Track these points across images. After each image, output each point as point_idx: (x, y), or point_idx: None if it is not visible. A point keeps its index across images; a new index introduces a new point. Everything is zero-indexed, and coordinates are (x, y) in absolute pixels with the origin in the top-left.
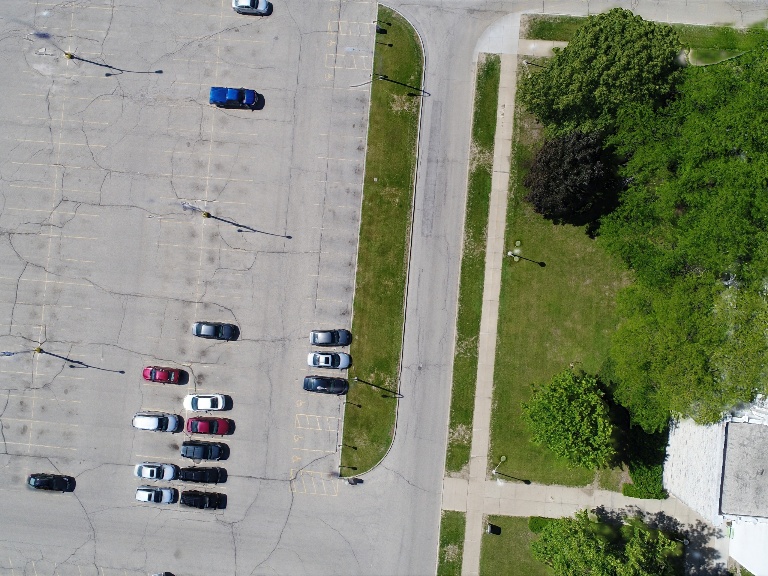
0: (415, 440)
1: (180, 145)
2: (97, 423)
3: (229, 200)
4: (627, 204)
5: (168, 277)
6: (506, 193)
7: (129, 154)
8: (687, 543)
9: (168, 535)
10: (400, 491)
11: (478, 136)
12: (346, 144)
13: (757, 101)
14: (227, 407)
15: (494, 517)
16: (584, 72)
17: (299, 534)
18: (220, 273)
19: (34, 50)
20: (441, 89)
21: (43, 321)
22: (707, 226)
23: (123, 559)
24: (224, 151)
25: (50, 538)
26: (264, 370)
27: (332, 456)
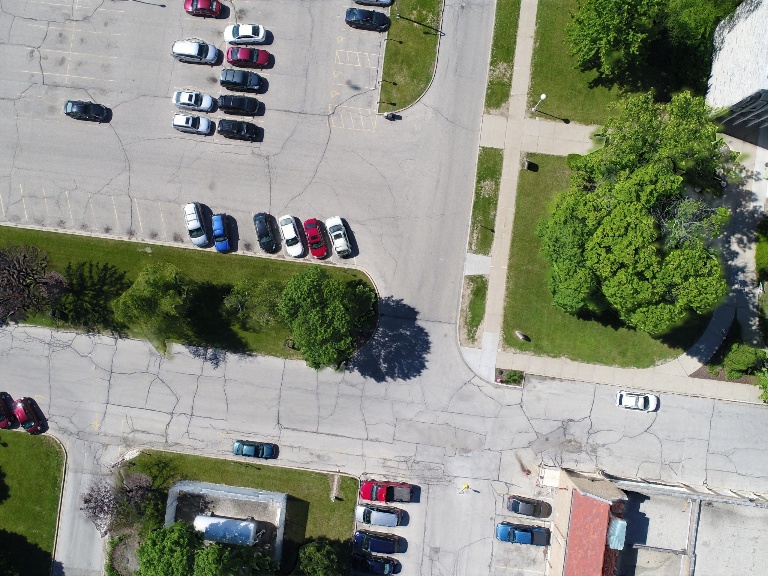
0: (455, 78)
1: None
2: (136, 56)
3: None
4: None
5: None
6: None
7: None
8: (725, 185)
9: (203, 167)
10: (438, 128)
11: None
12: None
13: None
14: (267, 41)
15: (532, 155)
16: None
17: (335, 168)
18: None
19: None
20: None
21: None
22: None
23: (157, 190)
24: None
25: (85, 168)
26: (306, 6)
27: (371, 92)
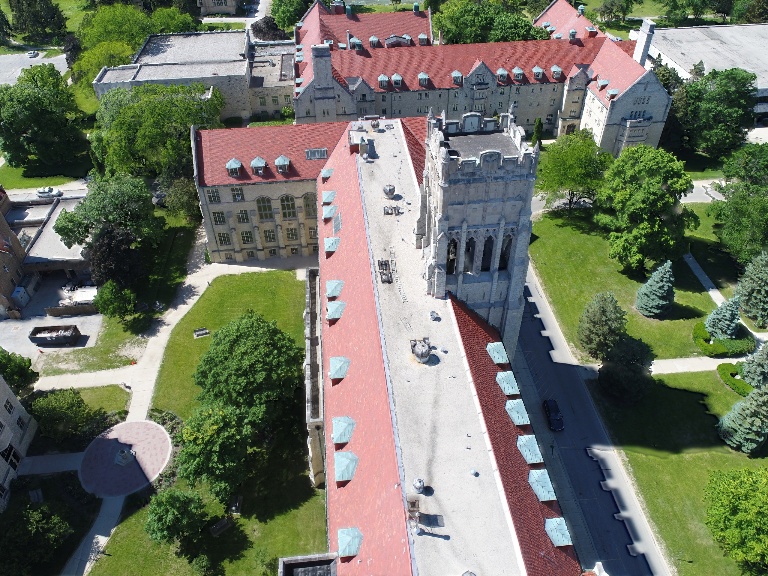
0: None
1: None
2: None
3: None
4: (84, 45)
5: None
6: None
7: None
8: None
9: None
10: None
11: None
12: None
13: None
14: None
15: None
16: None
17: None
18: None
19: None
20: None
21: None
22: None
23: None
24: None
25: None
26: None
27: None
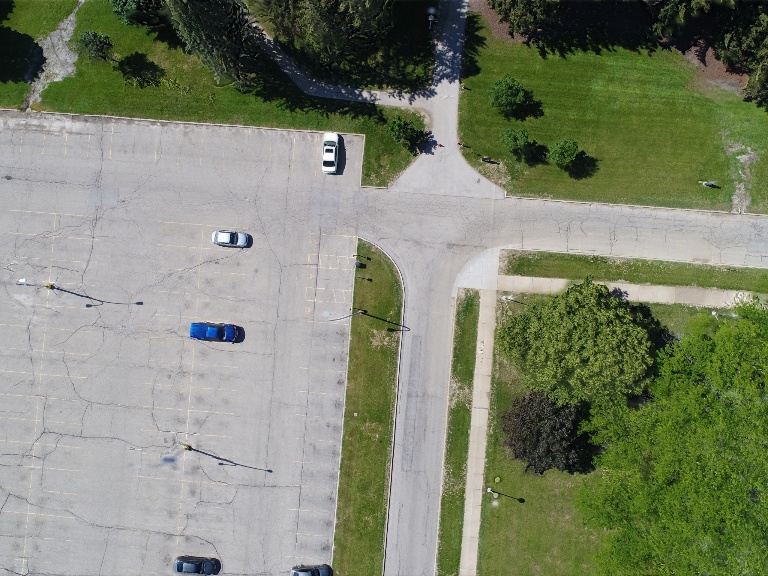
0: None
1: (161, 377)
2: None
3: (210, 433)
4: None
5: (149, 510)
6: (485, 429)
7: (110, 386)
8: None
9: None
10: None
11: (457, 372)
12: (326, 378)
13: (727, 434)
14: None
15: None
16: (559, 362)
17: None
18: (201, 506)
19: (15, 280)
20: (421, 324)
21: (25, 553)
22: (678, 542)
23: None
24: (205, 384)
25: None
26: None
27: None
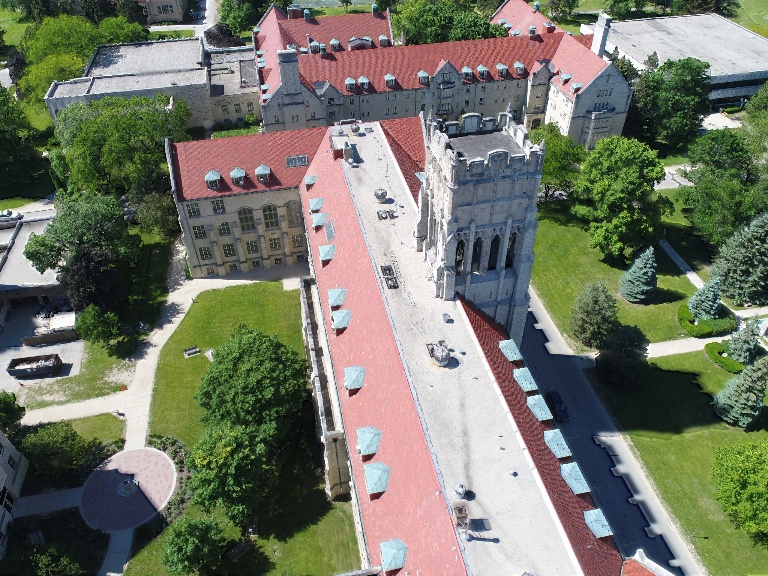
0: None
1: None
2: None
3: None
4: (29, 59)
5: None
6: None
7: None
8: None
9: None
10: None
11: None
12: None
13: None
14: None
15: None
16: None
17: None
18: None
19: None
20: None
21: None
22: None
23: None
24: None
25: None
26: None
27: None
